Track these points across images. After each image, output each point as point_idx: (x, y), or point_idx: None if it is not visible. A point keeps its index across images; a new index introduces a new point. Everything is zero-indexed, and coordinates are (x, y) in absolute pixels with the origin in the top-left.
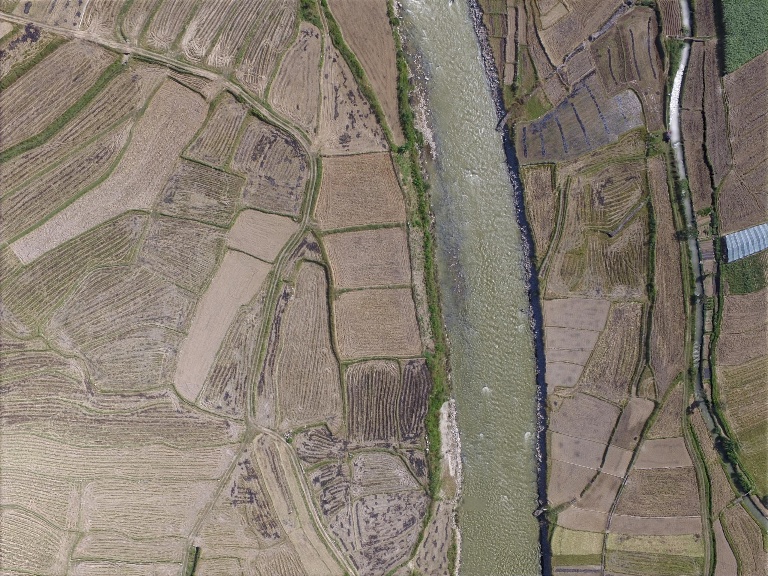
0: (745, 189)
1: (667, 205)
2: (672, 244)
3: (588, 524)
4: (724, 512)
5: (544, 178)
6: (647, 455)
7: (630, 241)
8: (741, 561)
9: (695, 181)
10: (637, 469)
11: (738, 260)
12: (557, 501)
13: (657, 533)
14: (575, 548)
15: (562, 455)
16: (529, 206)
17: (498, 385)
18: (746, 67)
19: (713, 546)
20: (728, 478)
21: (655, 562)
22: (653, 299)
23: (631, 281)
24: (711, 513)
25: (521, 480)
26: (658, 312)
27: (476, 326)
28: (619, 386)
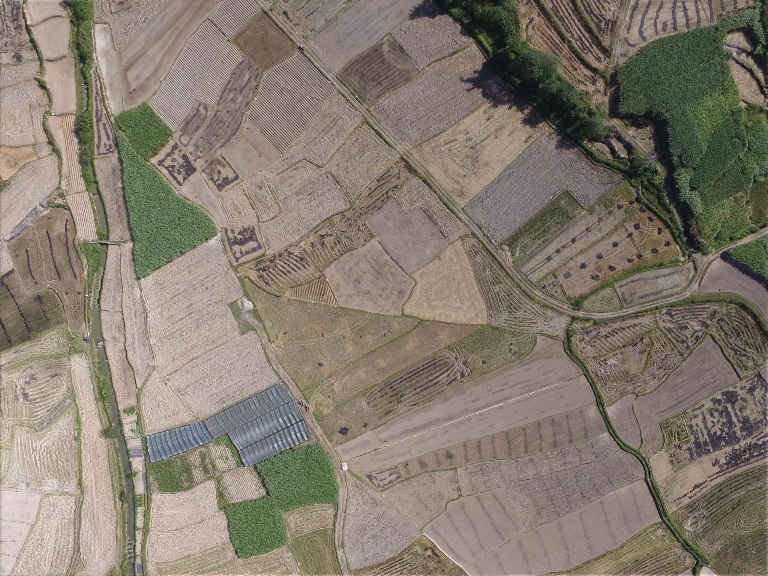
0: (169, 390)
1: (93, 403)
2: (100, 441)
3: None
4: None
5: None
6: None
7: (60, 436)
8: None
9: (119, 380)
10: None
11: (163, 460)
12: None
13: None
14: None
15: None
16: None
17: None
18: (164, 271)
19: None
20: None
21: None
22: (83, 494)
23: (62, 475)
24: None
25: None
26: (88, 507)
27: None
28: None
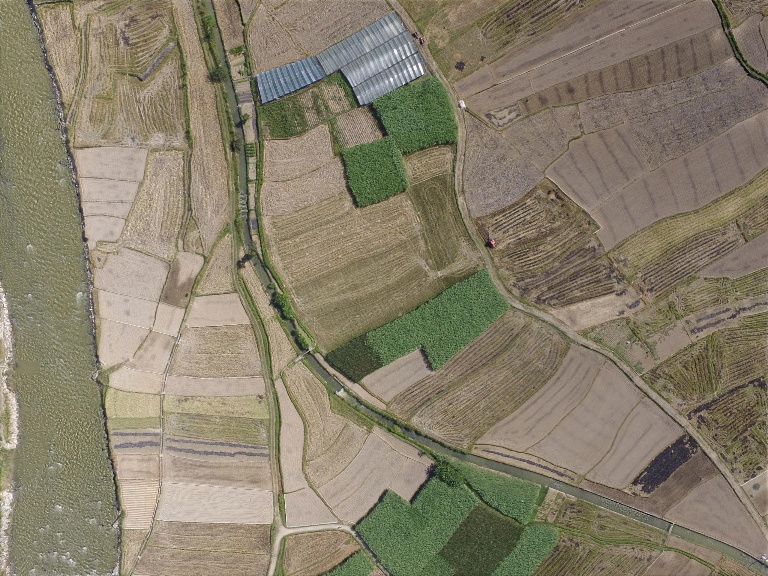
0: (277, 25)
1: (197, 44)
2: (206, 86)
3: (142, 385)
4: (285, 371)
5: (64, 18)
6: (200, 312)
7: (164, 85)
8: (307, 422)
9: (224, 17)
10: (190, 327)
11: (274, 101)
12: (110, 362)
13: (217, 394)
14: (131, 411)
15: (111, 314)
16: (50, 48)
17: (42, 242)
18: None
19: (278, 407)
20: (287, 335)
21: (218, 425)
22: (191, 146)
23: (168, 128)
24: (272, 372)
25: (77, 342)
26: (197, 160)
27: (12, 180)
28: (166, 240)
